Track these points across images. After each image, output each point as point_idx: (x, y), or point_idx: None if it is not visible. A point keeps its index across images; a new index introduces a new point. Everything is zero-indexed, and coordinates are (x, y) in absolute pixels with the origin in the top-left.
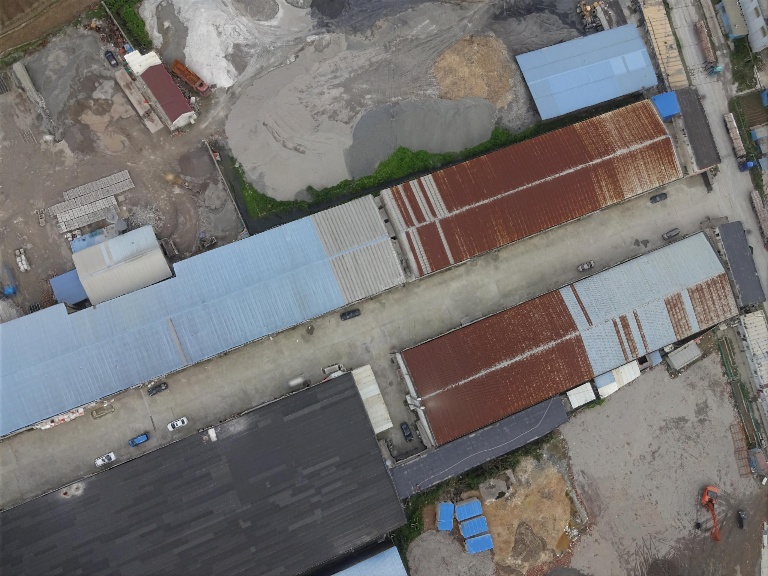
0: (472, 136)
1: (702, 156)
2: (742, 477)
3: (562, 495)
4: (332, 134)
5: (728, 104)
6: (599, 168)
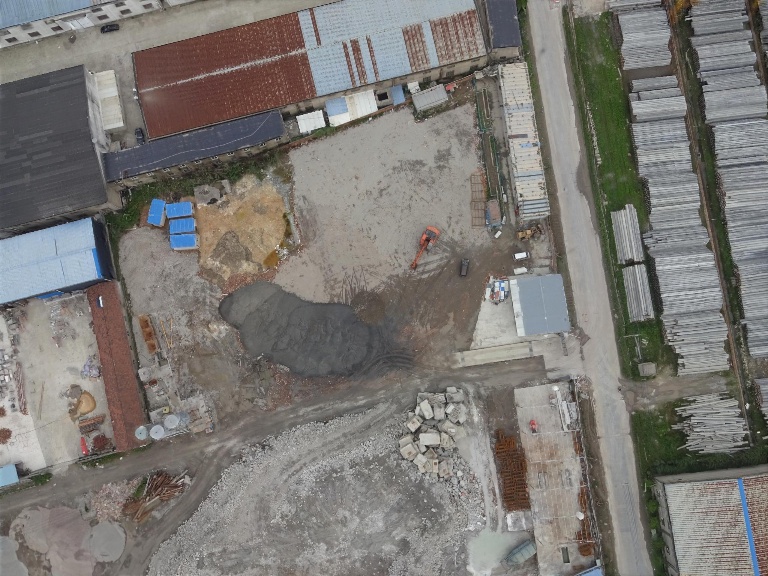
0: None
1: None
2: (474, 228)
3: (278, 215)
4: None
5: None
6: None
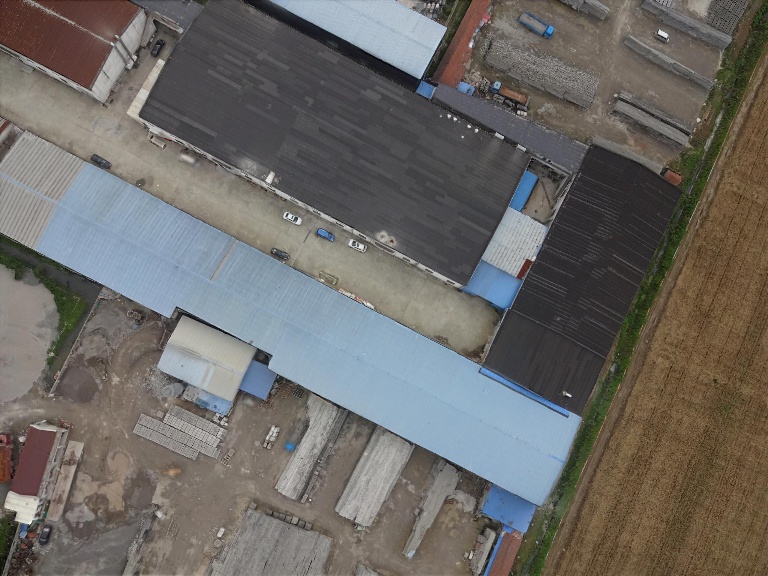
0: None
1: None
2: None
3: None
4: None
5: None
6: None
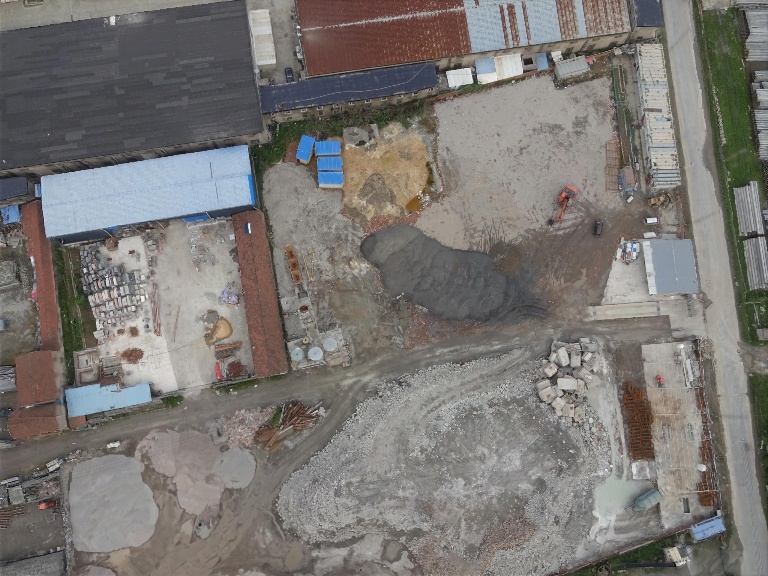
0: None
1: None
2: (608, 191)
3: (422, 163)
4: None
5: None
6: None
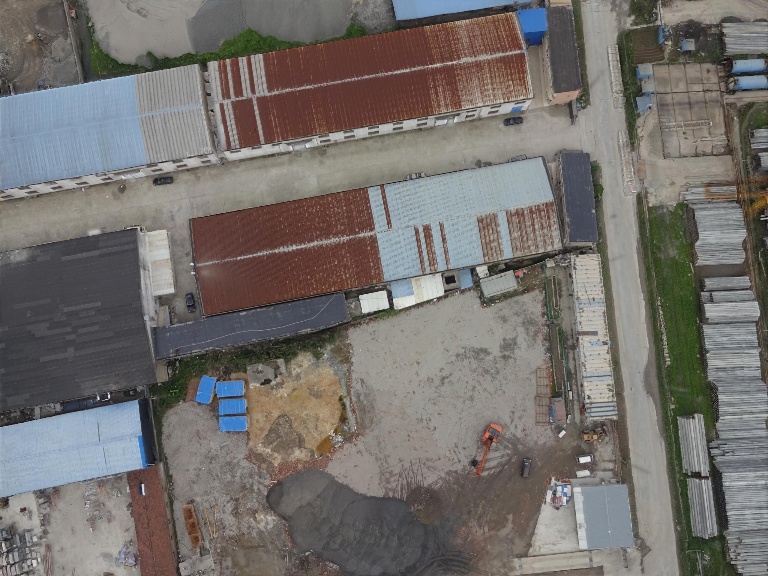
0: (323, 28)
1: (561, 79)
2: (538, 424)
3: (334, 398)
4: (176, 3)
5: (617, 36)
6: (438, 73)
